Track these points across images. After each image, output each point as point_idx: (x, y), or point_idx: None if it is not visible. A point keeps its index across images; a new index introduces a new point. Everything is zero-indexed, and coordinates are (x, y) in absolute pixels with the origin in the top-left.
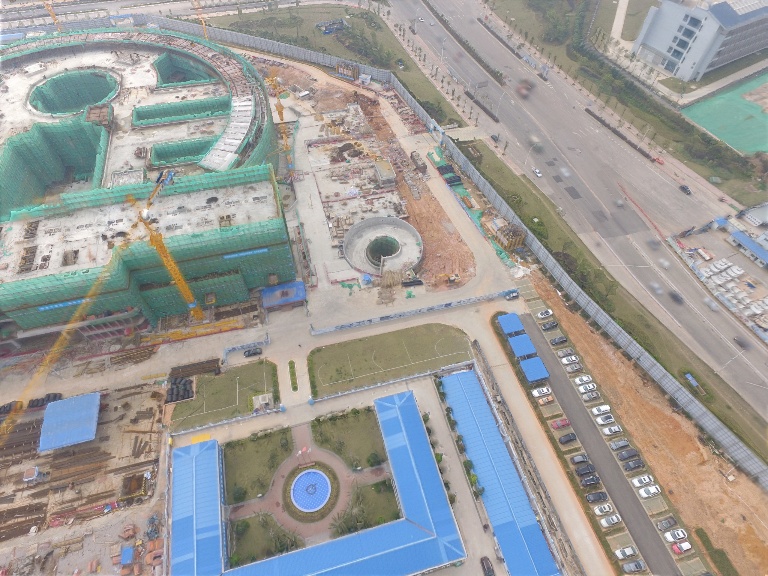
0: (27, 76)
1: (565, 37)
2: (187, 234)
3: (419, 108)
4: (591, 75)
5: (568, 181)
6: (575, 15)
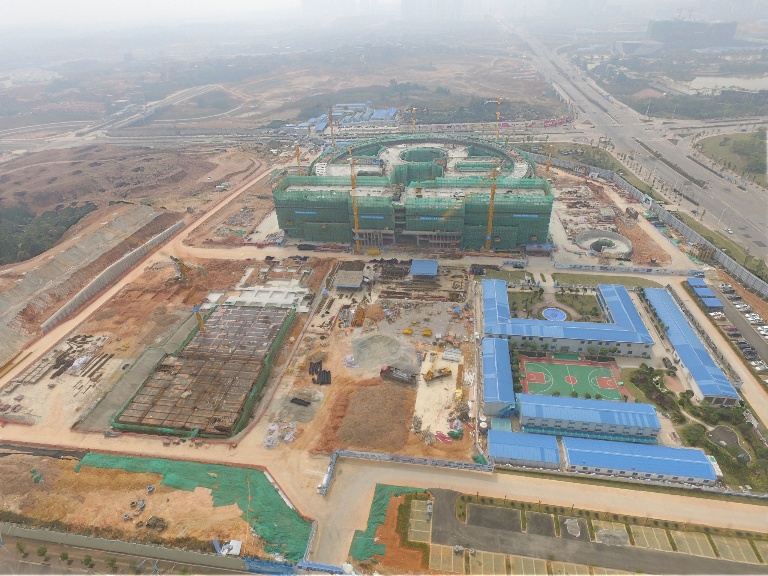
0: (398, 149)
1: (766, 169)
2: (501, 196)
3: (635, 190)
4: None
5: (756, 238)
6: None
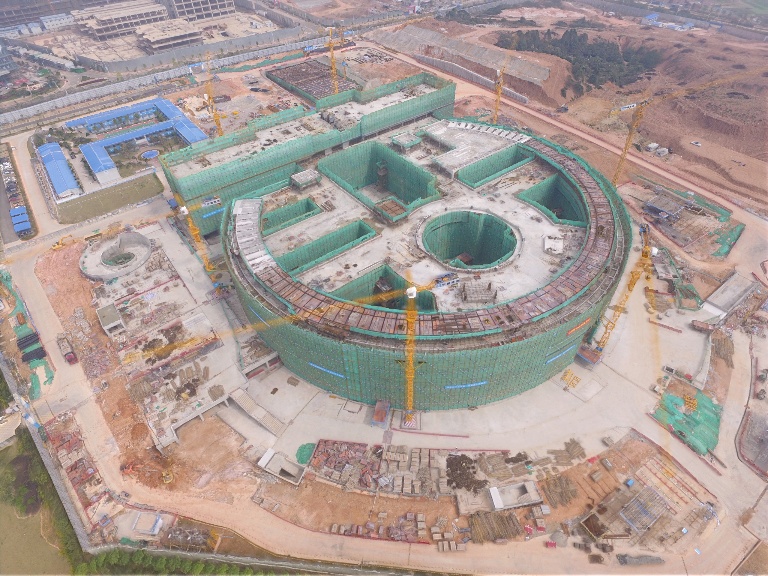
0: None
1: None
2: None
3: None
4: None
5: None
6: None
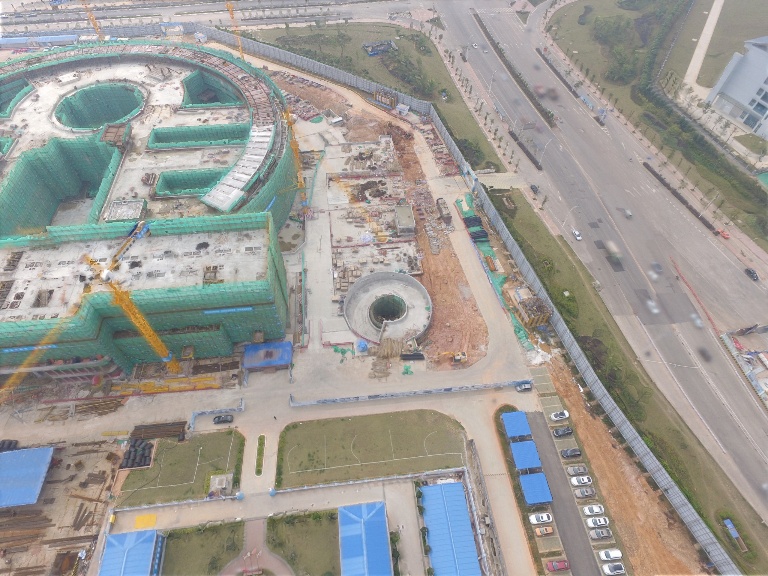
0: (60, 85)
1: (631, 77)
2: None
3: (455, 148)
4: (655, 123)
5: (611, 249)
6: (646, 52)
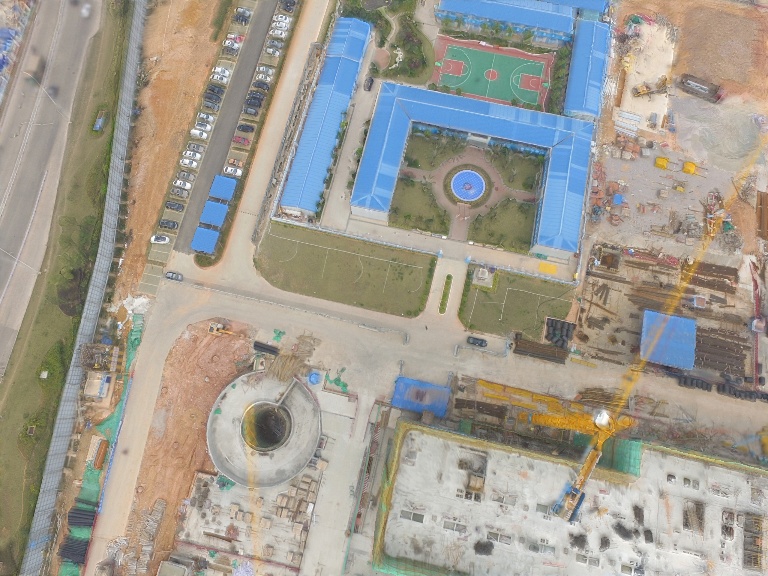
0: None
1: None
2: None
3: None
4: None
5: None
6: None
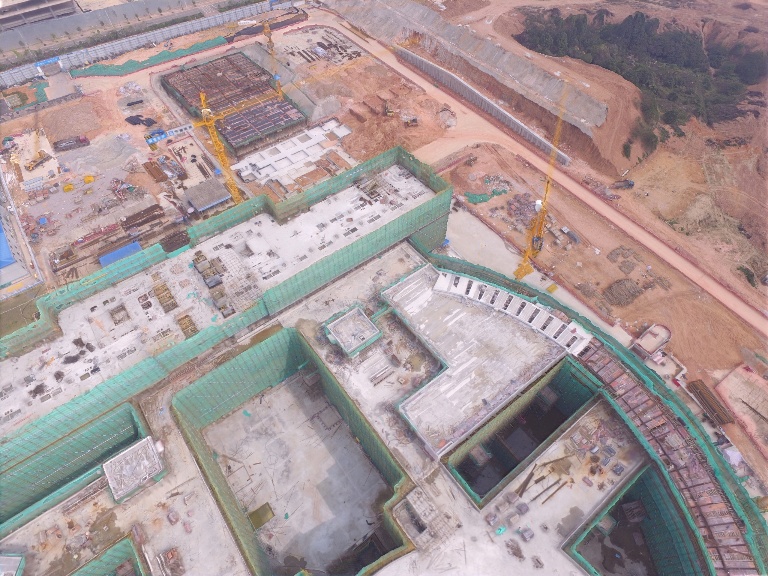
0: None
1: None
2: None
3: None
4: None
5: None
6: None
